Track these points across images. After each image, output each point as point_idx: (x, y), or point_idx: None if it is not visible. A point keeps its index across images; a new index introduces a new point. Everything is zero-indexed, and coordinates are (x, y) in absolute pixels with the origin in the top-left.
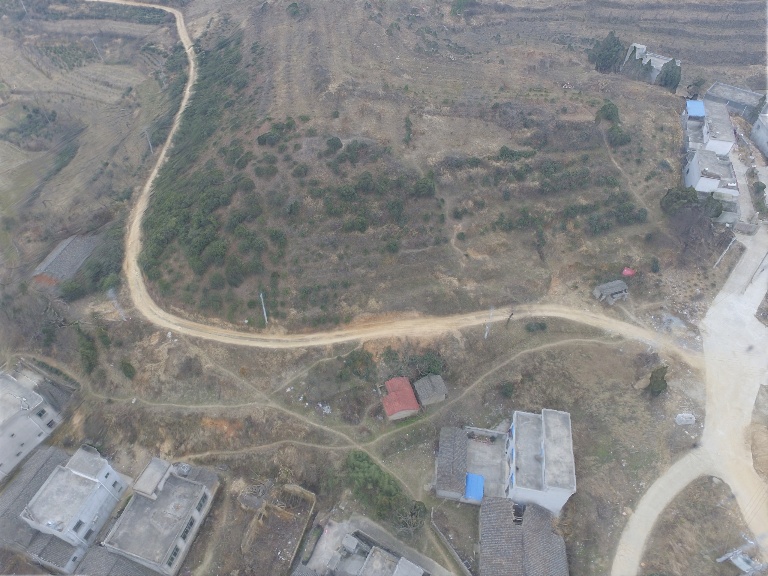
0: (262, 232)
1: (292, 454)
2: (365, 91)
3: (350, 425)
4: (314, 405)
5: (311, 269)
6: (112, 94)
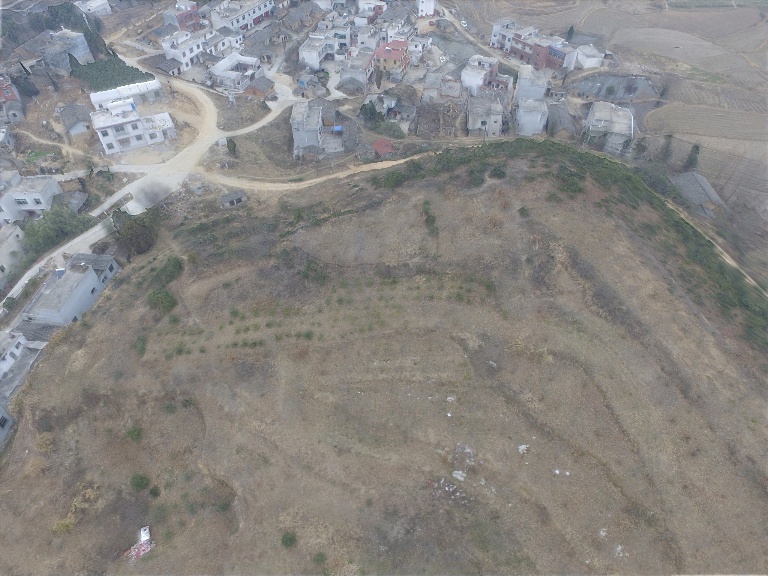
0: None
1: None
2: (511, 258)
3: None
4: None
5: None
6: None
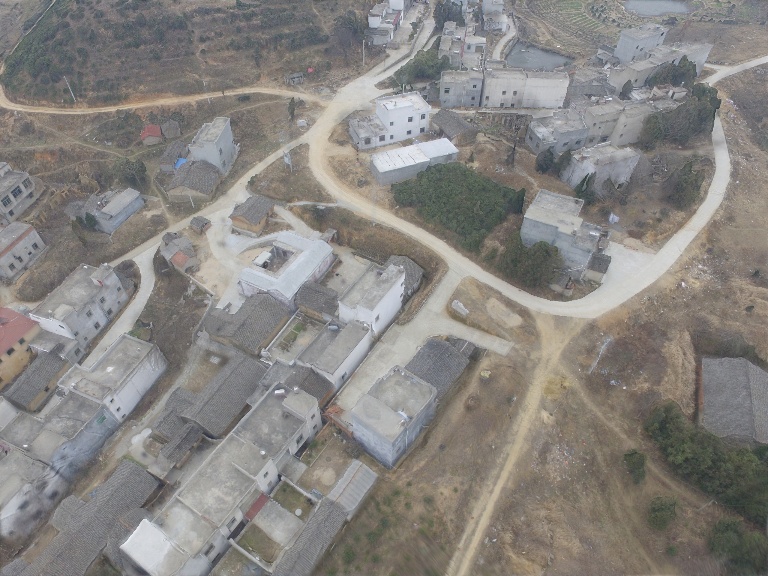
0: (73, 50)
1: (87, 167)
2: None
3: (121, 149)
4: (102, 142)
5: (104, 70)
6: (4, 9)
